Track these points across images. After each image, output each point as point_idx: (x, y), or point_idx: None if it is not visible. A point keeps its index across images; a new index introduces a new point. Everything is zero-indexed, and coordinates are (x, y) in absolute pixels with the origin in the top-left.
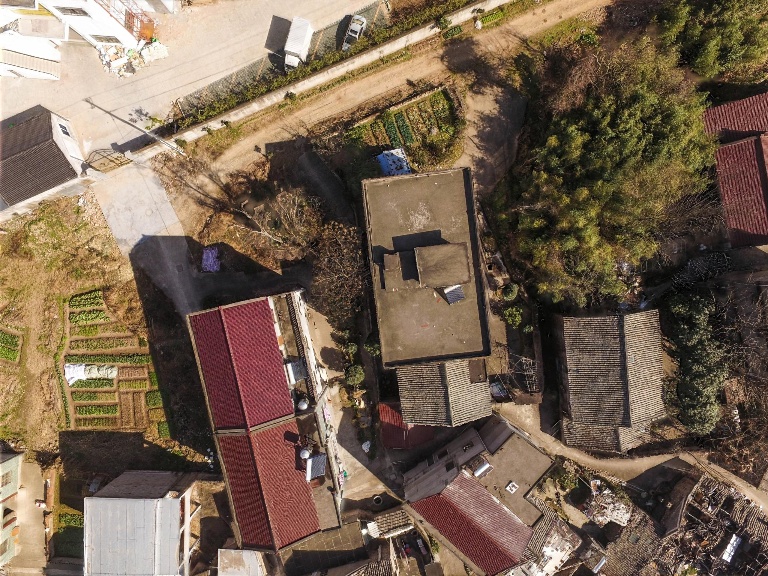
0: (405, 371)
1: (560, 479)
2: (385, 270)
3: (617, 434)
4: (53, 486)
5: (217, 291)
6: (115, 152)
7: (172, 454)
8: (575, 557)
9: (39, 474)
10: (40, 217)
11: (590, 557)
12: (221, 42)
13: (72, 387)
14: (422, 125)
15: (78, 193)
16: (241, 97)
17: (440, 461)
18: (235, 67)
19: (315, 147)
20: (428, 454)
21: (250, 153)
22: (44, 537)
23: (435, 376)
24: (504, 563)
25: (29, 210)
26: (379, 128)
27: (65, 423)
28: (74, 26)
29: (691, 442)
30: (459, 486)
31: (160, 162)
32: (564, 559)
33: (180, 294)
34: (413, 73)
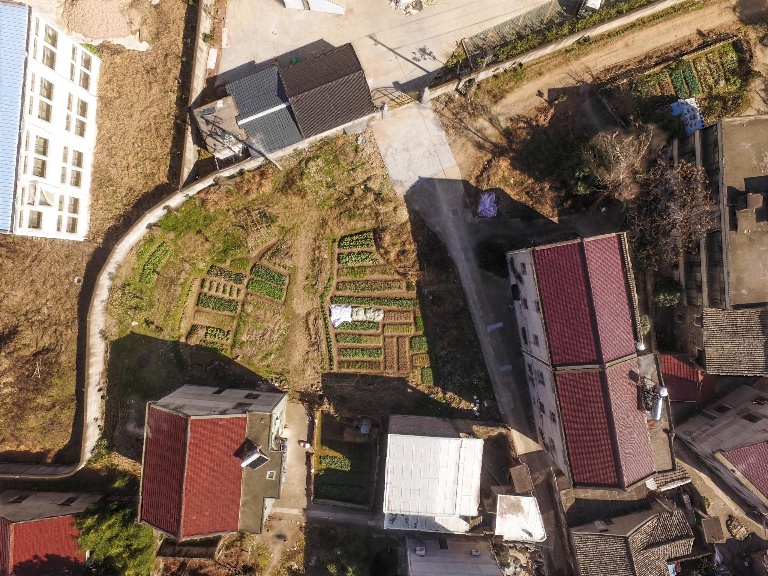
0: (714, 320)
1: None
2: (739, 211)
3: None
4: None
5: (492, 237)
6: (396, 91)
7: (435, 400)
8: None
9: (303, 415)
10: (317, 154)
11: None
12: None
13: (338, 329)
14: (709, 76)
15: (357, 131)
16: (541, 38)
17: (728, 415)
18: (523, 9)
19: None
20: (697, 410)
21: (532, 98)
22: (305, 478)
23: (754, 325)
24: None
25: (306, 146)
26: (665, 77)
27: (328, 365)
28: None
29: None
30: None
31: (441, 103)
32: None
33: (454, 238)
34: (703, 23)
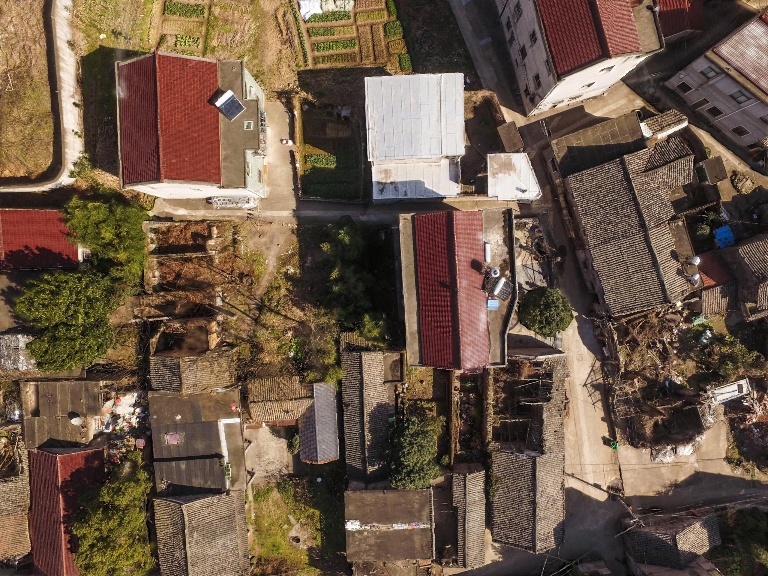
0: None
1: None
2: None
3: None
4: (297, 125)
5: None
6: None
7: None
8: None
9: (282, 113)
10: None
11: None
12: None
13: (309, 21)
14: None
15: None
16: None
17: None
18: None
19: None
20: (689, 61)
21: None
22: (292, 178)
23: None
24: None
25: None
26: None
27: (303, 62)
28: None
29: None
30: None
31: None
32: None
33: None
34: None
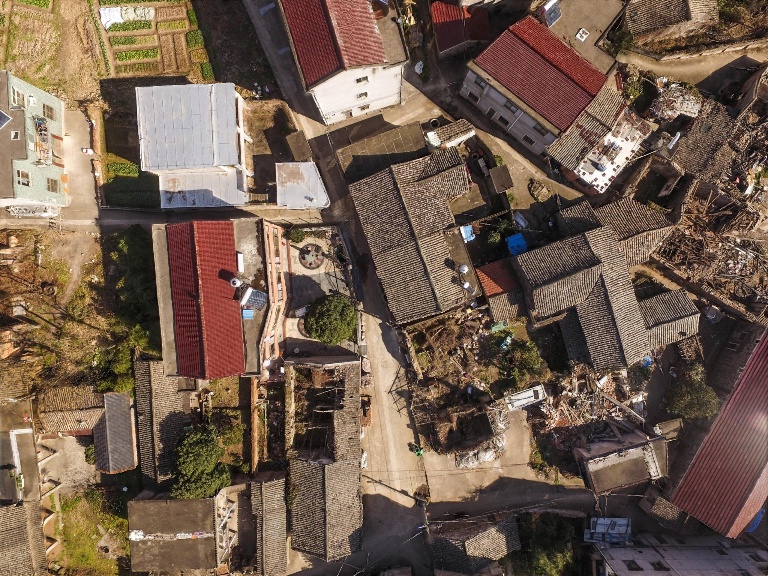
0: None
1: (624, 86)
2: None
3: (686, 0)
4: (98, 133)
5: None
6: None
7: None
8: (646, 151)
9: (83, 121)
10: None
11: (662, 146)
12: None
13: (109, 30)
14: None
15: None
16: None
17: None
18: None
19: None
20: None
21: None
22: (94, 187)
23: None
24: (580, 103)
25: None
26: None
27: (105, 71)
28: None
29: (760, 34)
30: (528, 27)
31: None
32: (635, 149)
33: None
34: None
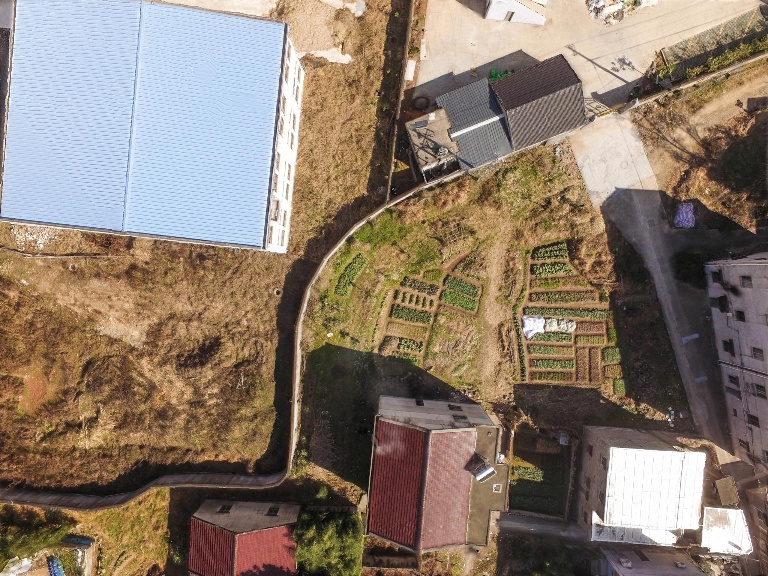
0: None
1: None
2: None
3: None
4: None
5: (688, 248)
6: (595, 101)
7: (627, 411)
8: None
9: None
10: (514, 165)
11: None
12: None
13: (531, 340)
14: None
15: (554, 142)
16: (751, 47)
17: None
18: (724, 18)
19: None
20: None
21: (731, 107)
22: None
23: None
24: None
25: (503, 158)
26: None
27: (520, 376)
28: None
29: None
30: None
31: (640, 113)
32: None
33: (650, 249)
34: None
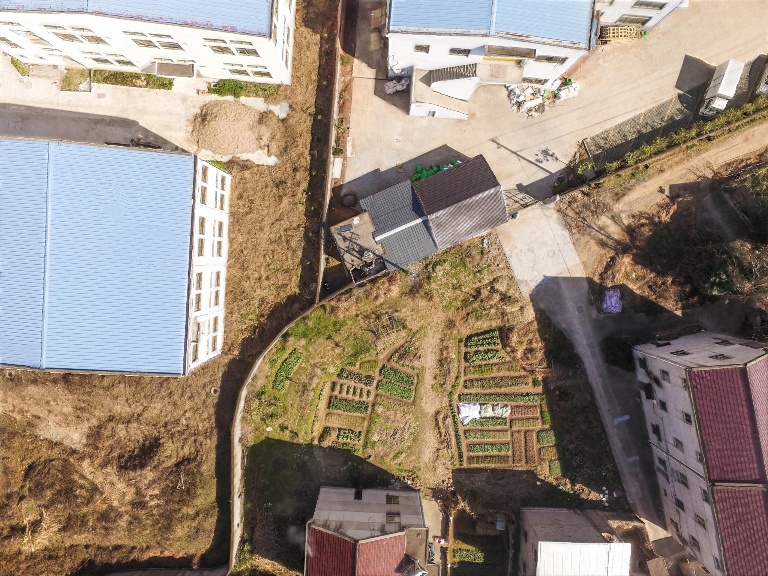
0: None
1: None
2: None
3: None
4: None
5: (617, 332)
6: (520, 193)
7: (563, 491)
8: None
9: (436, 511)
10: (444, 258)
11: None
12: (632, 82)
13: (467, 426)
14: None
15: (482, 234)
16: (668, 140)
17: None
18: (644, 107)
19: (755, 193)
20: None
21: (654, 194)
22: None
23: None
24: None
25: None
26: None
27: (458, 461)
28: (524, 70)
29: None
30: None
31: (565, 203)
32: None
33: (579, 335)
34: None
